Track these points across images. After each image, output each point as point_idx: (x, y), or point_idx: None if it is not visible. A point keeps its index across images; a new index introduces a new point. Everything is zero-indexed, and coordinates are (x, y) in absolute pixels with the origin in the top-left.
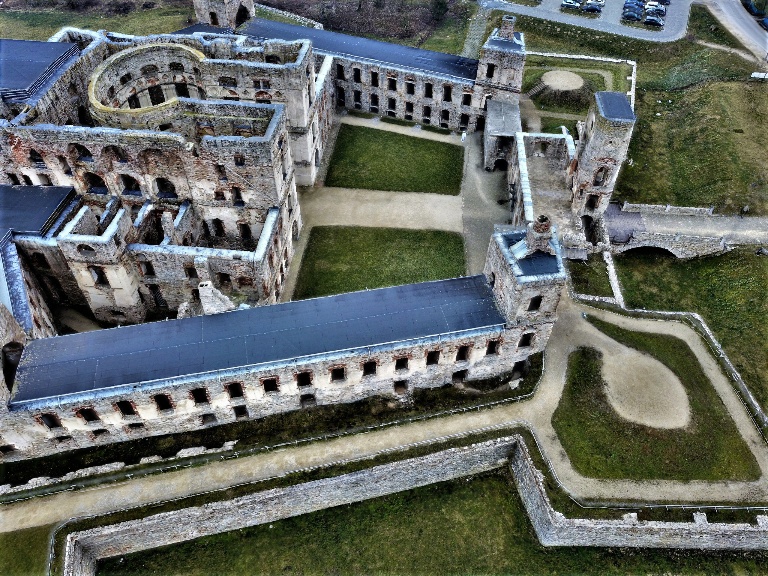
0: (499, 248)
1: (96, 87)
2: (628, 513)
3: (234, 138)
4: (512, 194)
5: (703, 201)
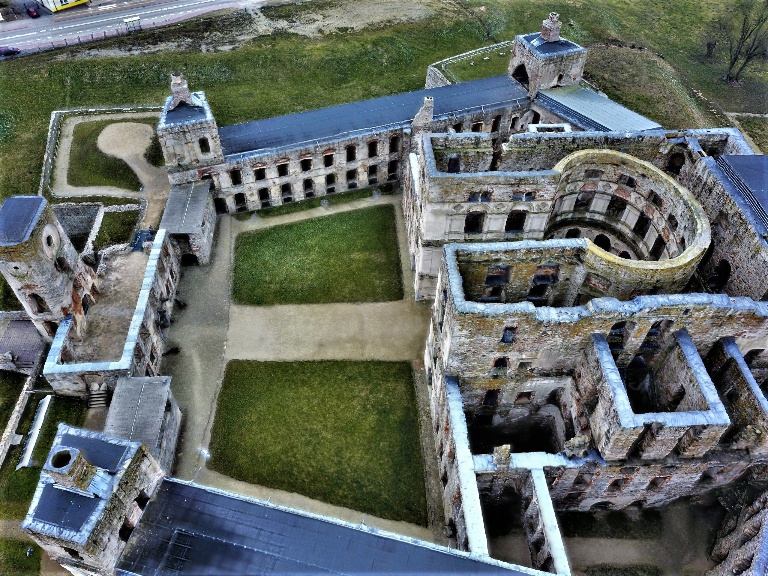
0: None
1: (667, 183)
2: None
3: (458, 134)
4: None
5: None
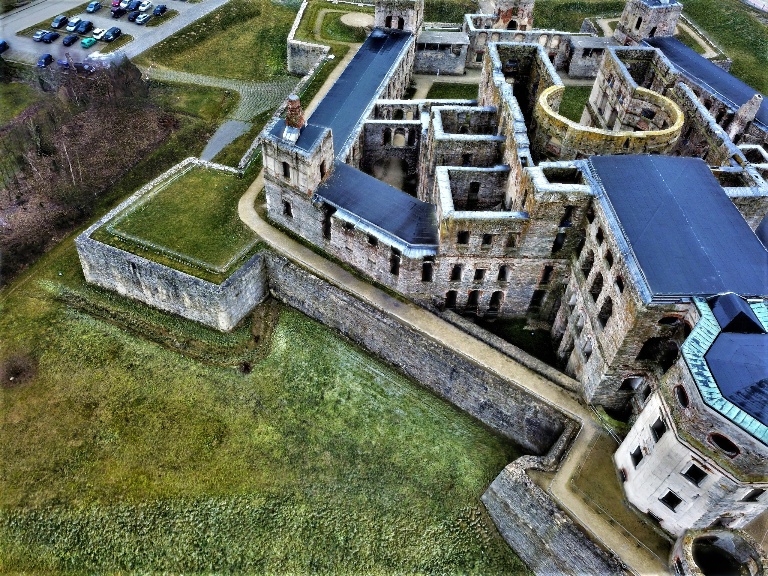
0: (661, 8)
1: None
2: (713, 45)
3: (667, 60)
4: None
5: (460, 15)
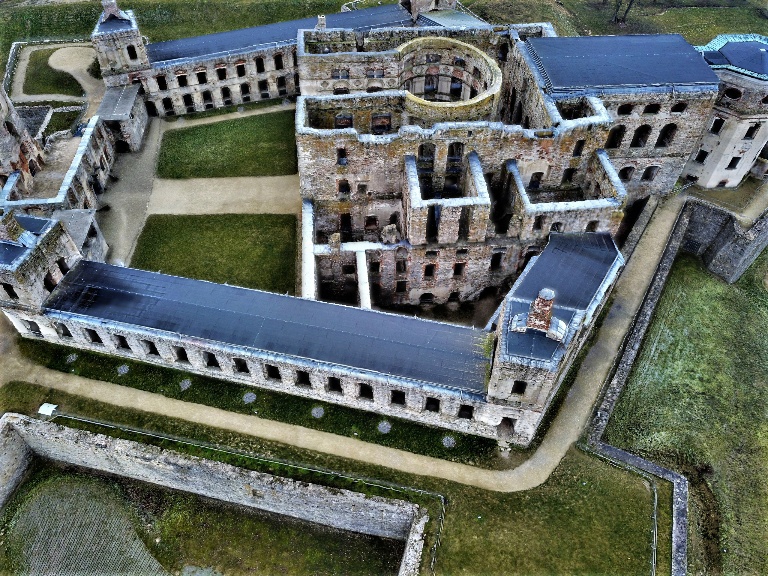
0: None
1: (481, 57)
2: None
3: (326, 29)
4: (96, 176)
5: None
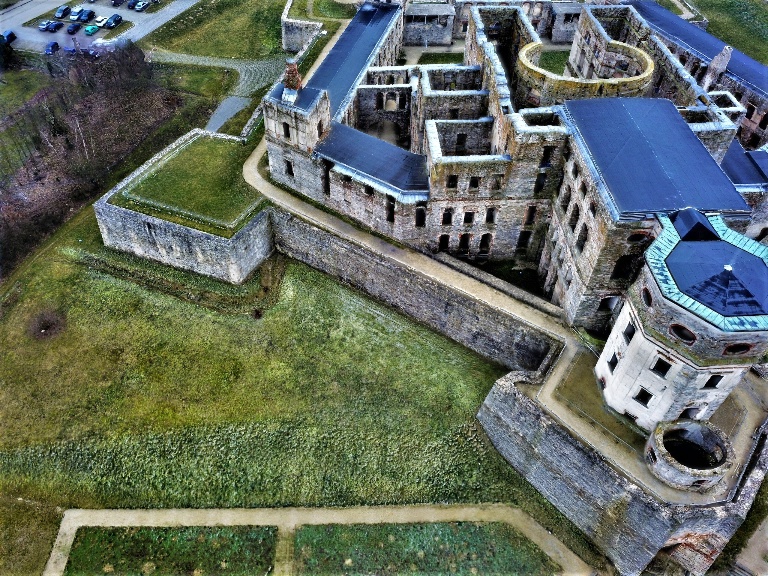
0: None
1: None
2: (690, 7)
3: (639, 16)
4: None
5: None
